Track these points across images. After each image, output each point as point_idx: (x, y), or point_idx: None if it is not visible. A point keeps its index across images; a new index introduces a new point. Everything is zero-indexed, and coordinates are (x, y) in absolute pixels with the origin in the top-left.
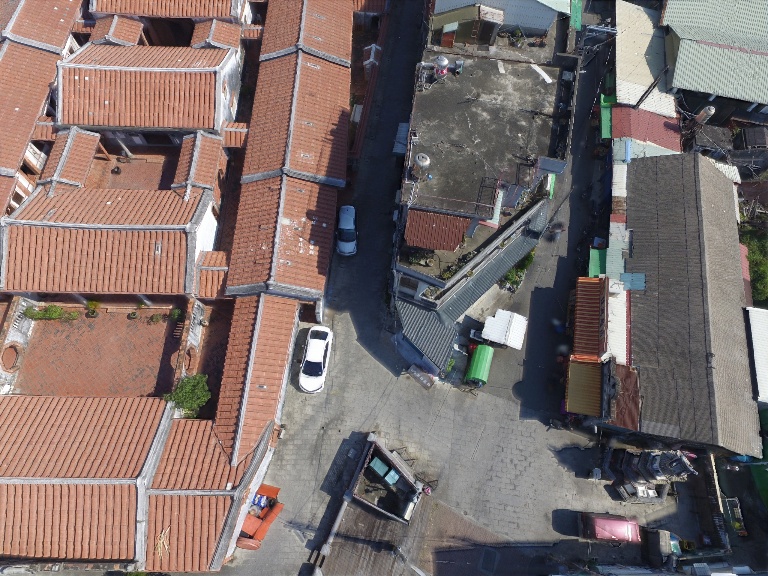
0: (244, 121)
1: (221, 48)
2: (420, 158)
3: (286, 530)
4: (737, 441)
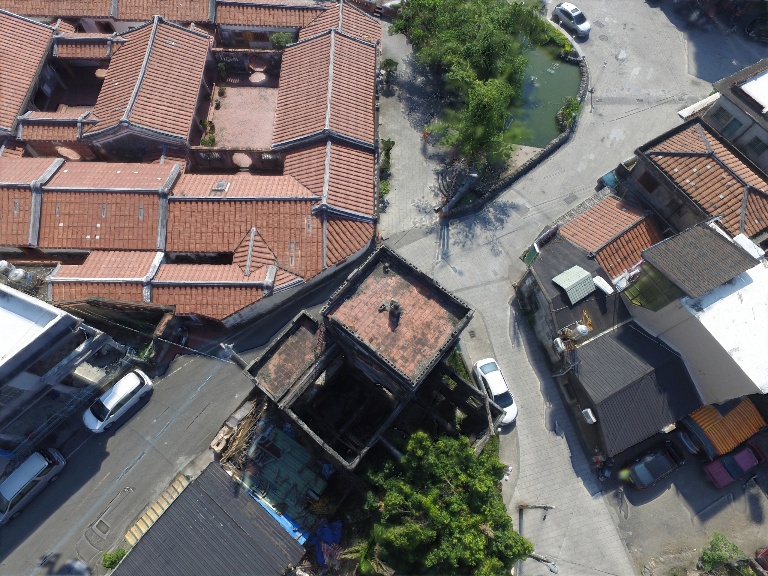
0: None
1: None
2: None
3: None
4: None
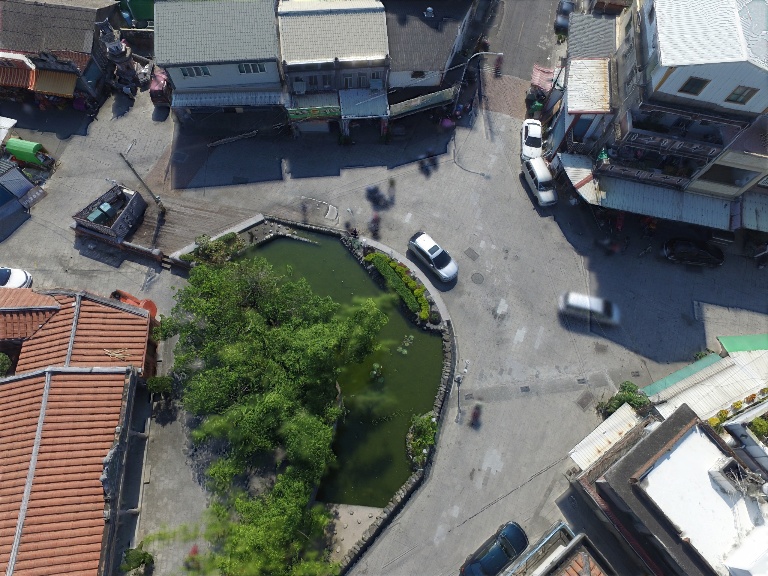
0: None
1: None
2: None
3: (145, 289)
4: (101, 5)
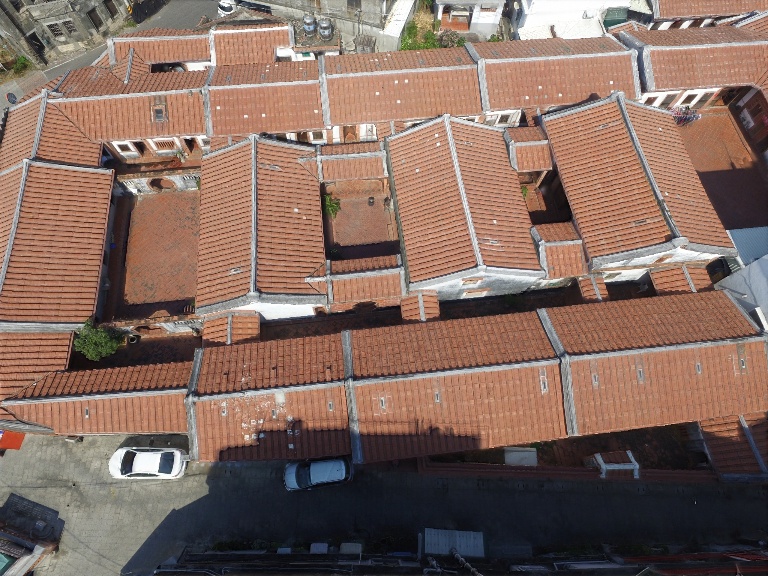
0: (469, 309)
1: (540, 260)
2: None
3: None
4: None
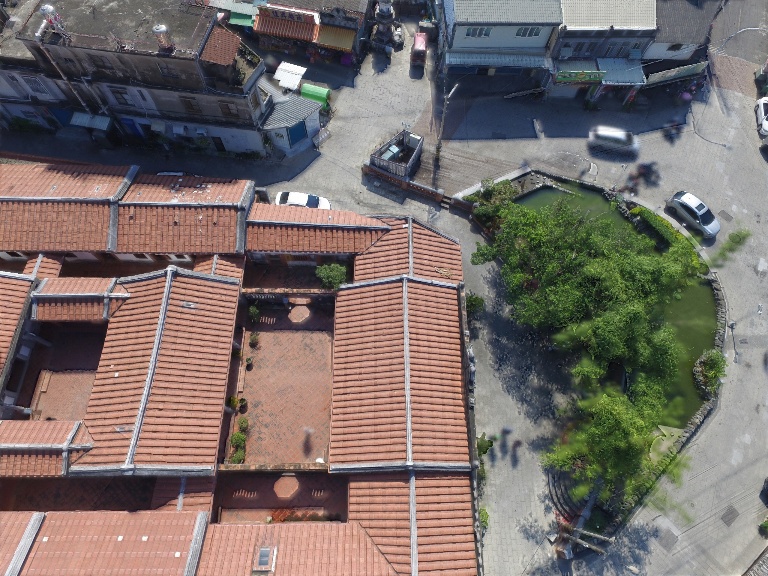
0: None
1: None
2: (158, 28)
3: None
4: None
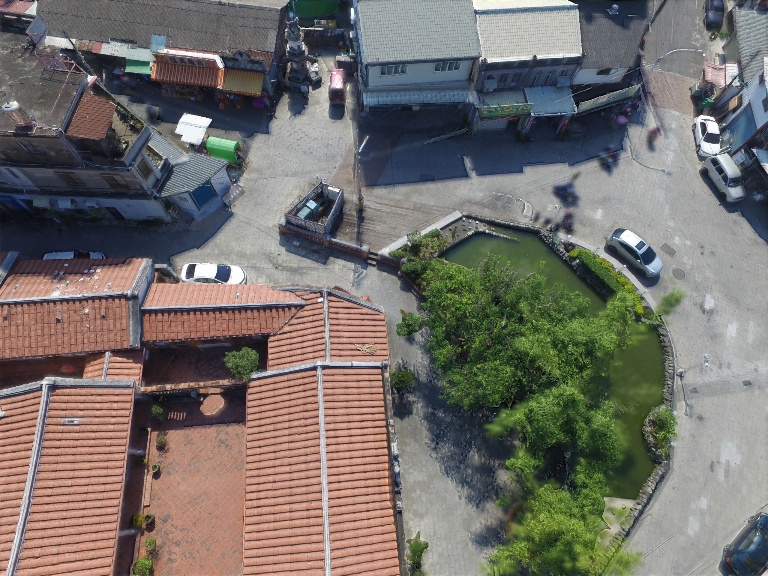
0: None
1: None
2: (8, 106)
3: (356, 285)
4: (278, 4)
